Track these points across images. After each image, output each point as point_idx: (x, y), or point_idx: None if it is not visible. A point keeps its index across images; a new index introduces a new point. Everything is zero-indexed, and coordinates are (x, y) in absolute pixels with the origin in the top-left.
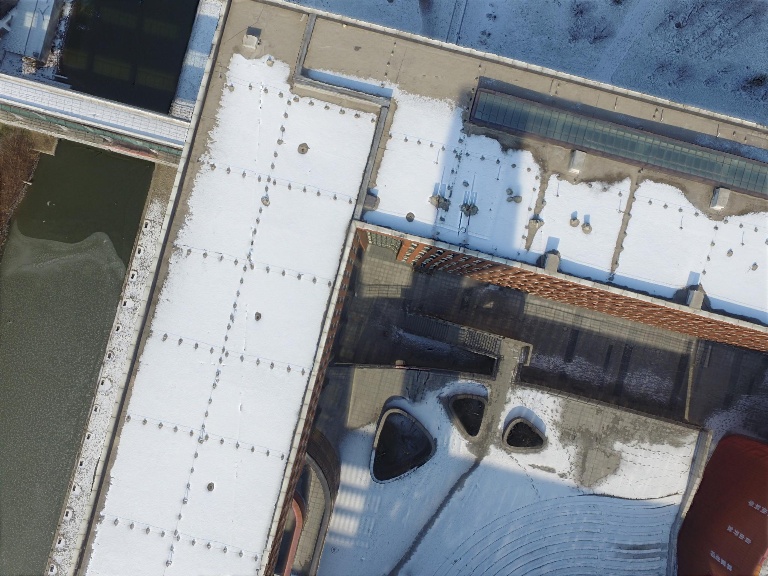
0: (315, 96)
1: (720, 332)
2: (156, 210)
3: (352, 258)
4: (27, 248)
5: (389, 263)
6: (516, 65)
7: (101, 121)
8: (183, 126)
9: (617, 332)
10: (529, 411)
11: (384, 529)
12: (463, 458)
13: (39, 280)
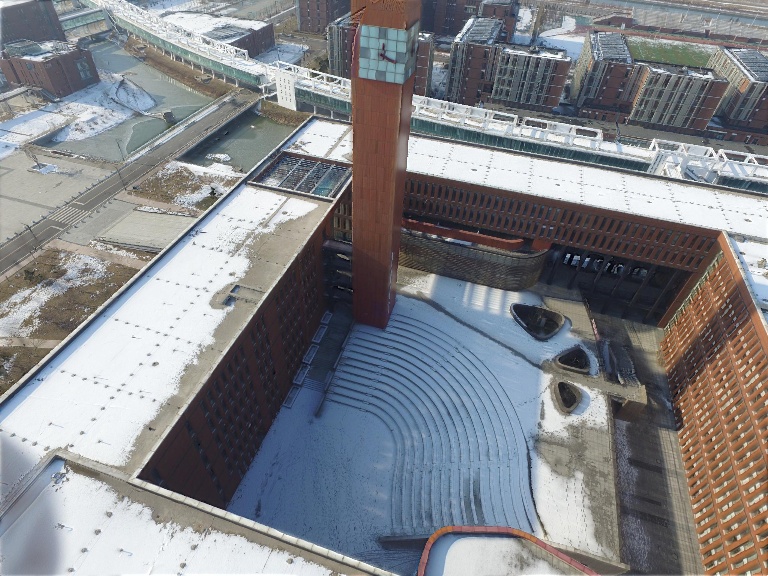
0: None
1: (761, 514)
2: None
3: (684, 262)
4: None
5: (655, 339)
6: None
7: None
8: None
9: (677, 511)
10: (588, 403)
11: (477, 310)
12: (537, 357)
13: None
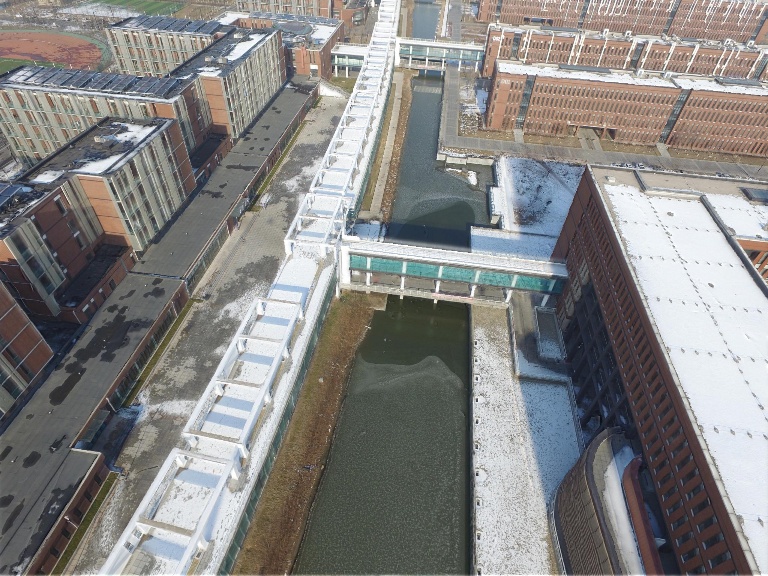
0: (660, 196)
1: None
2: (480, 333)
3: None
4: (372, 371)
5: None
6: (754, 181)
7: (462, 261)
8: (518, 261)
9: None
10: None
11: None
12: None
13: (386, 395)
